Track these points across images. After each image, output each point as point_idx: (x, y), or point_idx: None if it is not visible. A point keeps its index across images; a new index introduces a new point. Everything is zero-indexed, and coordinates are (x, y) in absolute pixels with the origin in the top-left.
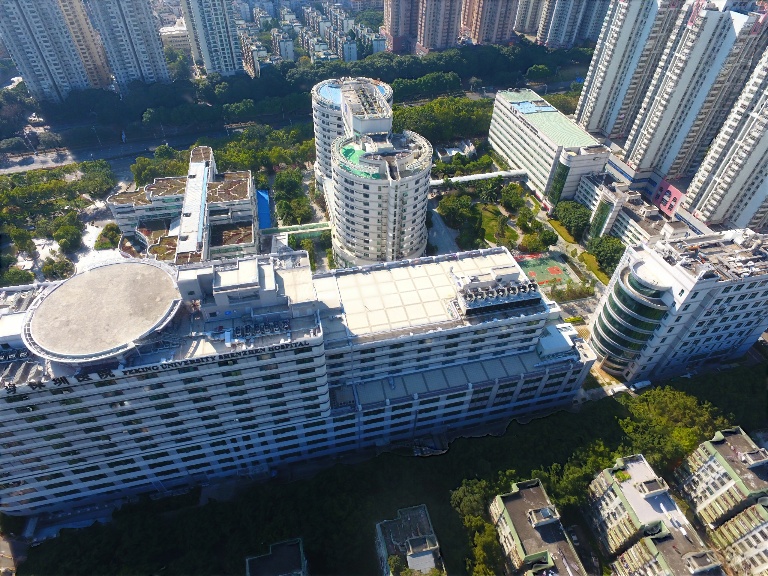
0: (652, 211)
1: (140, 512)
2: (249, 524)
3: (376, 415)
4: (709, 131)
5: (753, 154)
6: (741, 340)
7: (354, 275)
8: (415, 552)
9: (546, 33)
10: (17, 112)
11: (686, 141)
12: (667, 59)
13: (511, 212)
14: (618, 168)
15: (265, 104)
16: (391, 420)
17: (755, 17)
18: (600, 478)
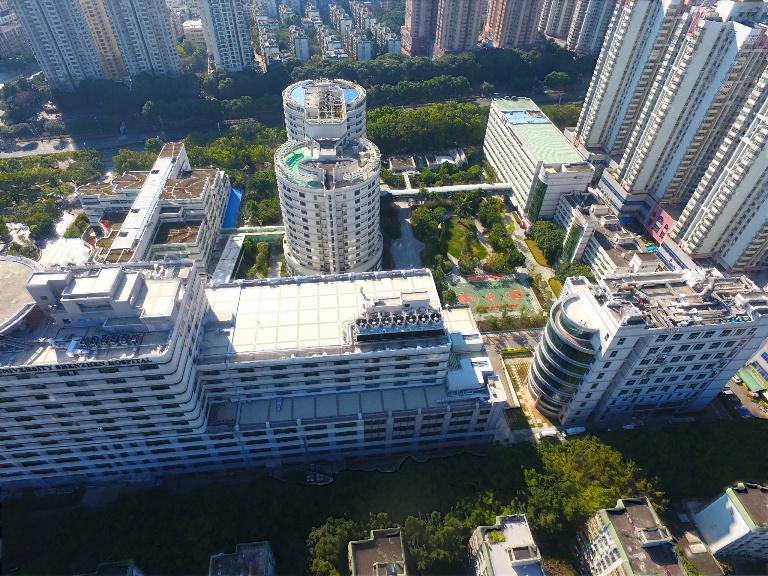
0: (626, 239)
1: (9, 508)
2: (107, 535)
3: (258, 436)
4: (710, 154)
5: (742, 184)
6: (696, 393)
7: (261, 287)
8: None
9: (576, 38)
10: (29, 99)
11: (682, 163)
12: (664, 72)
13: (487, 228)
14: (612, 188)
15: (263, 101)
16: (277, 443)
17: (759, 29)
18: (474, 535)
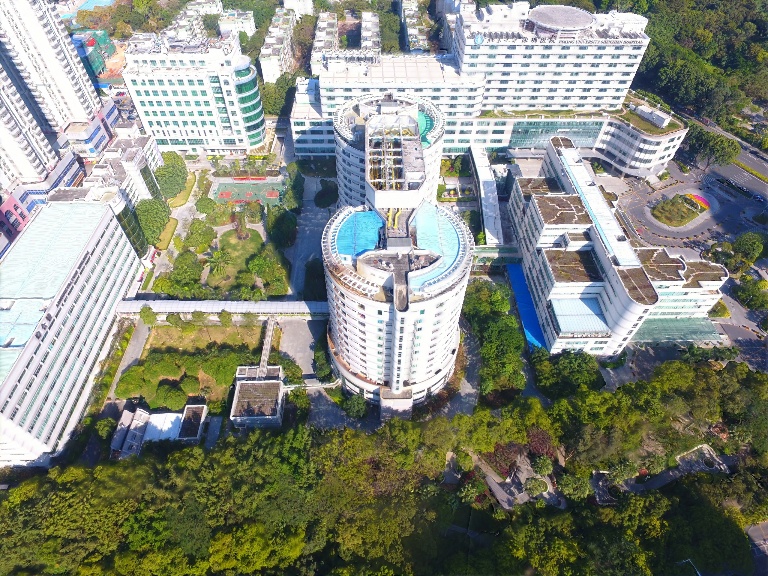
0: None
1: None
2: None
3: None
4: None
5: None
6: None
7: None
8: (420, 48)
9: None
10: None
11: None
12: None
13: None
14: None
15: None
16: None
17: None
18: None
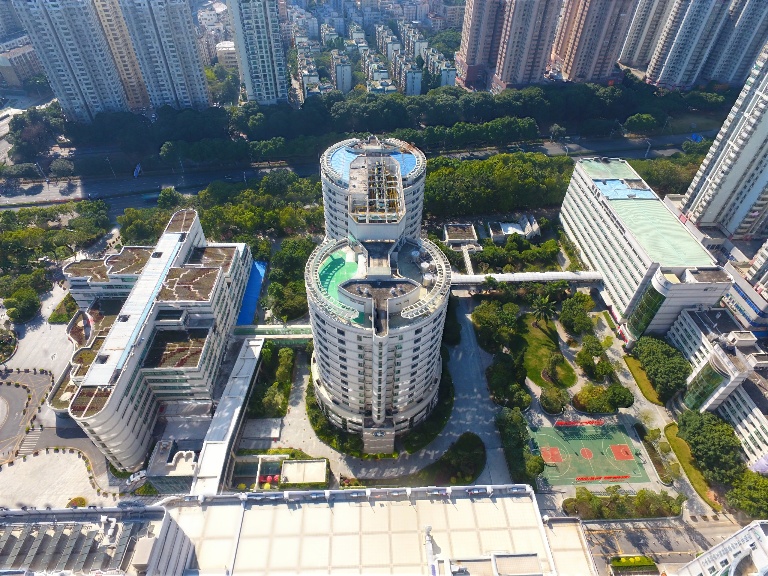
0: None
1: None
2: None
3: None
4: None
5: None
6: None
7: (274, 507)
8: None
9: (659, 70)
10: (39, 134)
11: None
12: None
13: (572, 335)
14: (740, 289)
15: (297, 144)
16: None
17: None
18: None
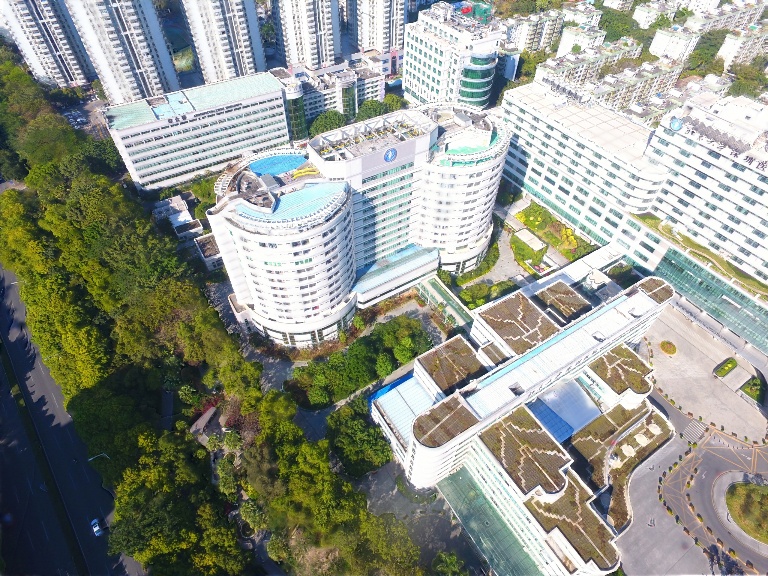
0: None
1: None
2: None
3: None
4: None
5: None
6: None
7: None
8: None
9: None
10: None
11: None
12: None
13: None
14: None
15: None
16: None
17: None
18: None
